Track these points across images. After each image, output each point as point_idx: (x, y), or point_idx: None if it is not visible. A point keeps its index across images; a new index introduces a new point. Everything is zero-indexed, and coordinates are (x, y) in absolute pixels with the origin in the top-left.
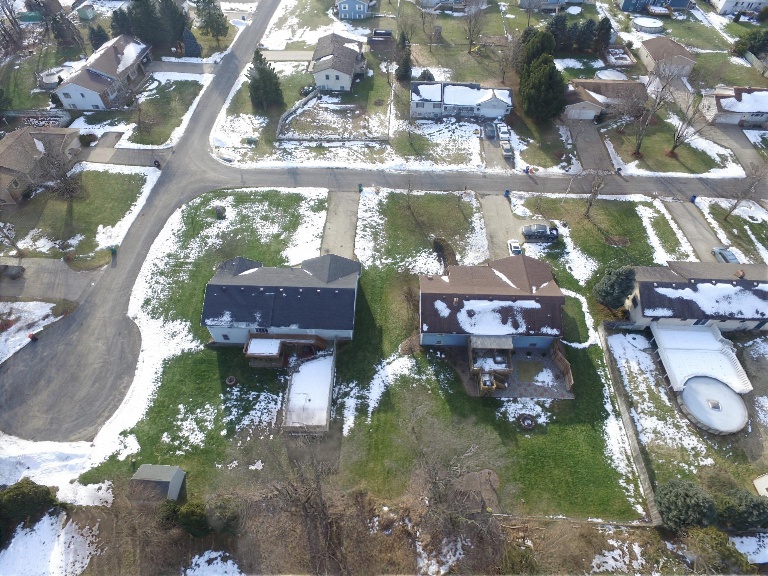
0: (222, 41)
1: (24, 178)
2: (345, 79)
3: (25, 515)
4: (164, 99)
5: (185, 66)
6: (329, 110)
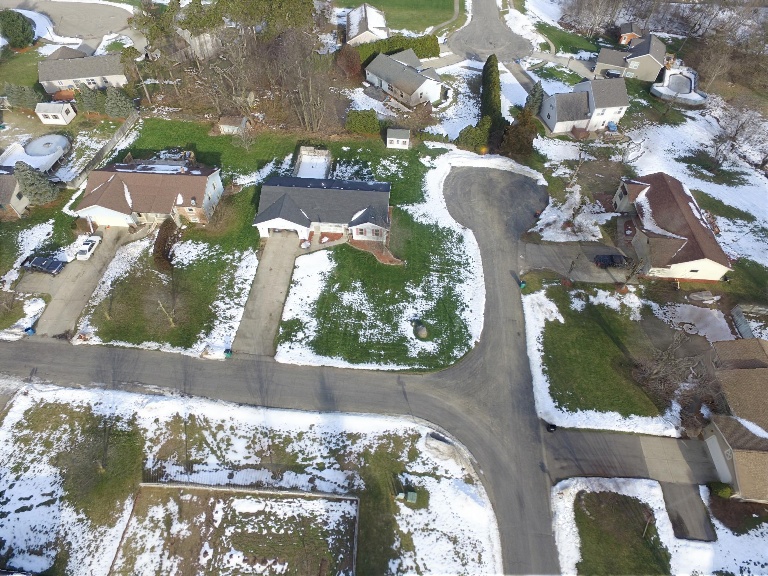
0: None
1: None
2: None
3: None
4: None
5: None
6: None
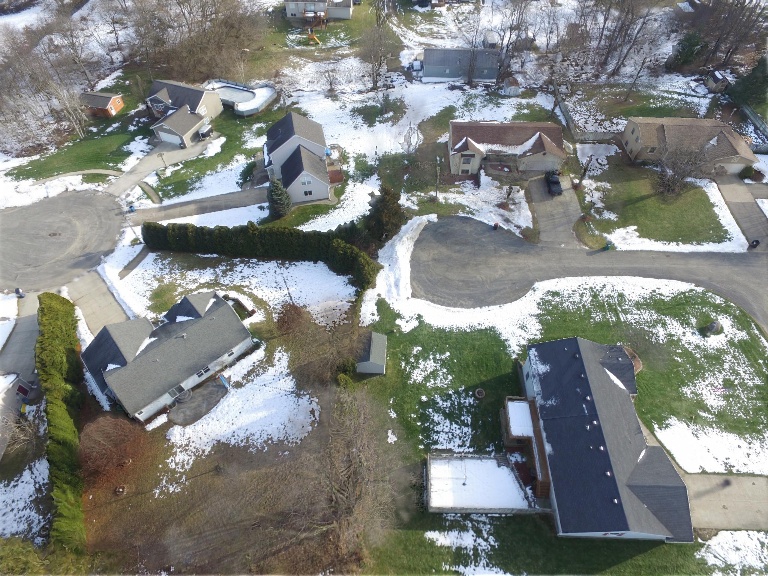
0: None
1: (664, 152)
2: None
3: None
4: None
5: None
6: None
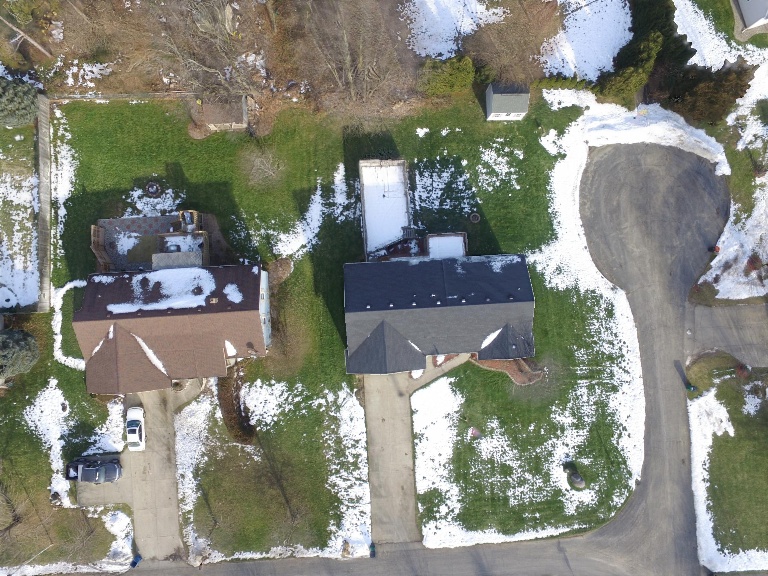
0: None
1: None
2: None
3: None
4: None
5: None
6: None
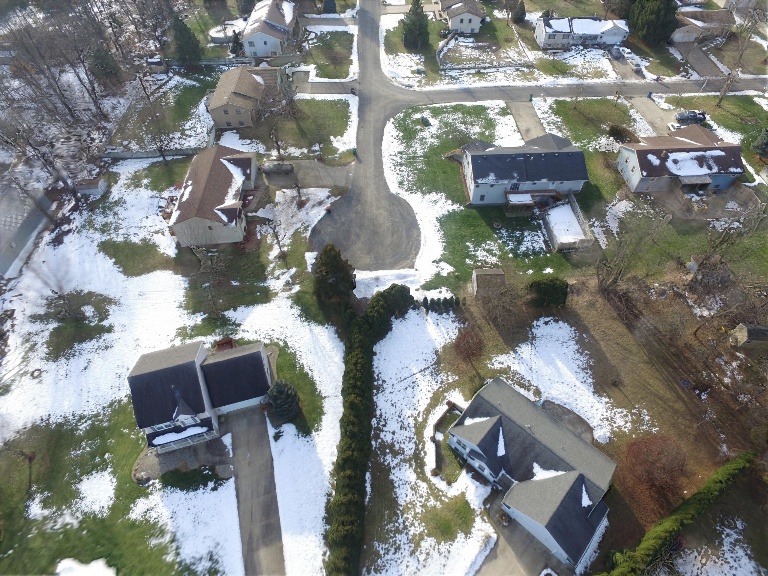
0: (348, 0)
1: (254, 105)
2: (477, 22)
3: (395, 310)
4: (326, 46)
5: (328, 20)
6: (470, 47)
